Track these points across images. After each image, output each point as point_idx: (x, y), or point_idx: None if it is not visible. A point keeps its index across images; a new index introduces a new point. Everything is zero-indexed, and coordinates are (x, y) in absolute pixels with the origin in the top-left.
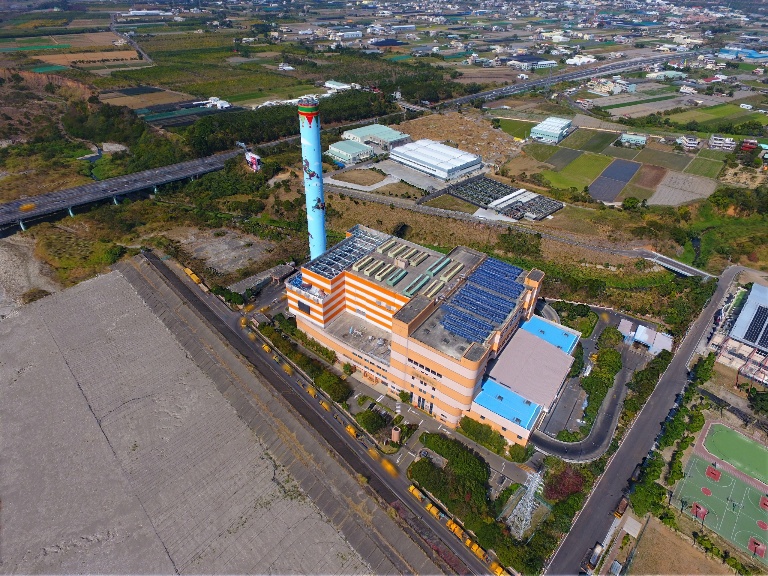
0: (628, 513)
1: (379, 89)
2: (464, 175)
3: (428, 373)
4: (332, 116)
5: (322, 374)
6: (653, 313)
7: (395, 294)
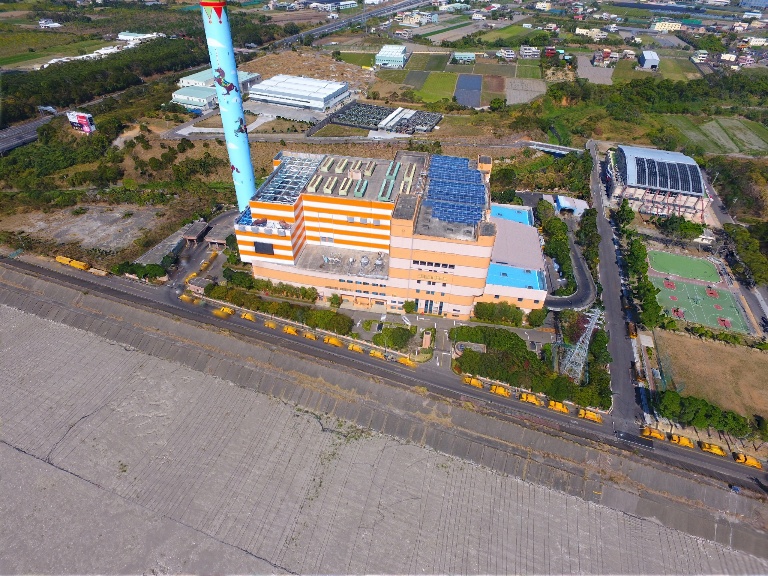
0: (638, 332)
1: (189, 37)
2: (337, 104)
3: (438, 269)
4: (152, 67)
5: (313, 313)
6: (559, 186)
7: (371, 202)
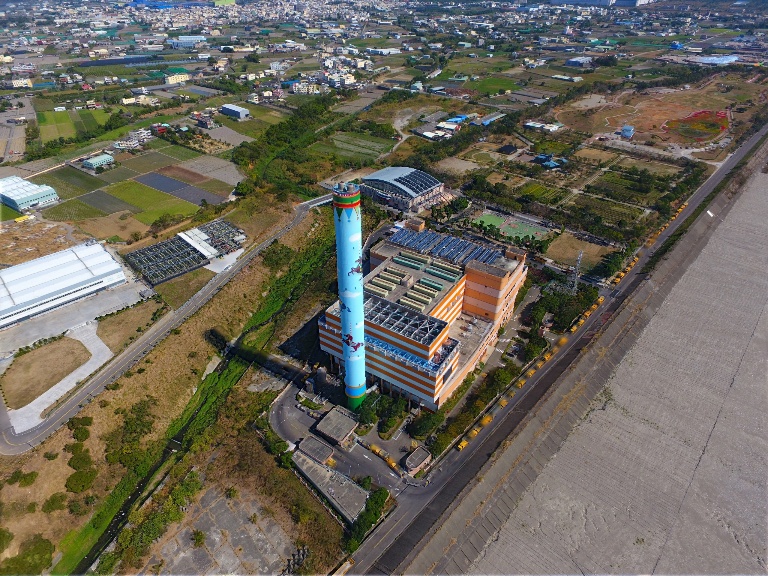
0: None
1: None
2: None
3: None
4: None
5: (496, 382)
6: None
7: None
